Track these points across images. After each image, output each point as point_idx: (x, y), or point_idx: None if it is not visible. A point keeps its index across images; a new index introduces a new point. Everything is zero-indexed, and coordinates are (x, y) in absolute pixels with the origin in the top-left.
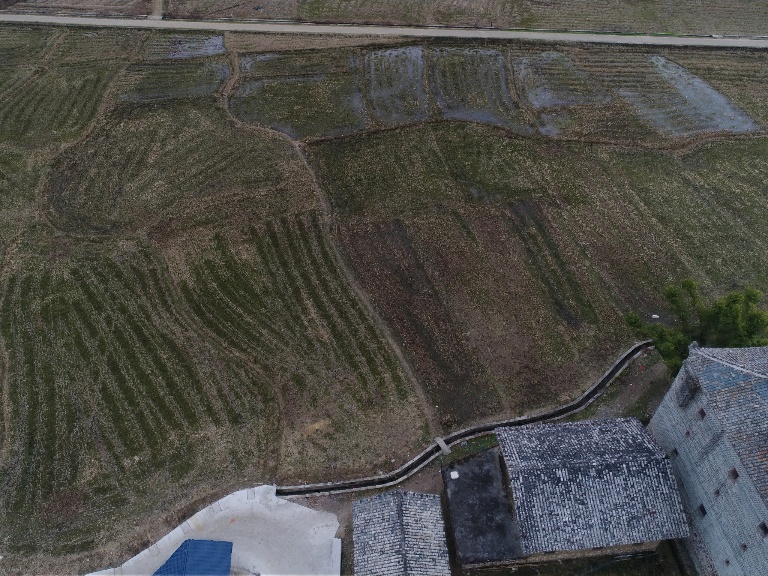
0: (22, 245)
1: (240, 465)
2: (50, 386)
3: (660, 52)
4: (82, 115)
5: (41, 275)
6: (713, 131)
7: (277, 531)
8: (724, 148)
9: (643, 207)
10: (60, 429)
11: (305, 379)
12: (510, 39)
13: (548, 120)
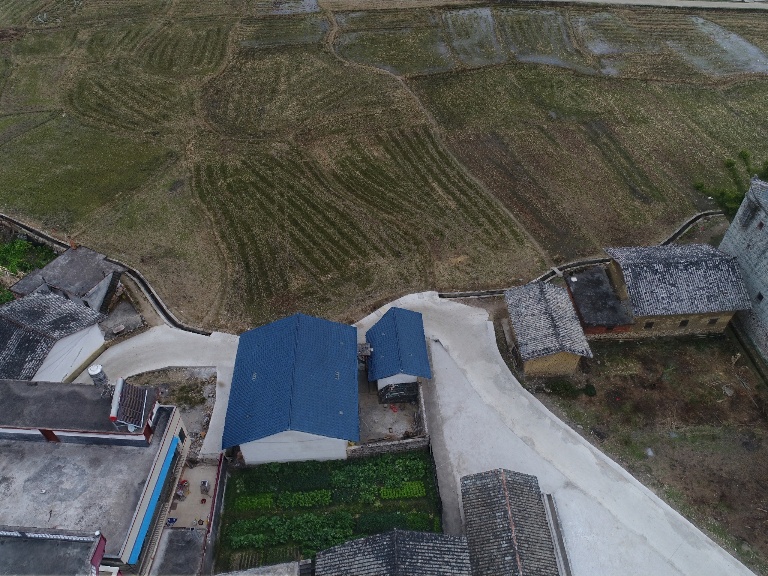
0: (196, 145)
1: (407, 281)
2: (250, 233)
3: (699, 13)
4: (214, 56)
5: (219, 164)
6: (749, 73)
7: (445, 316)
8: (759, 85)
9: (694, 126)
10: (266, 258)
11: (443, 232)
12: (567, 2)
13: (607, 64)
